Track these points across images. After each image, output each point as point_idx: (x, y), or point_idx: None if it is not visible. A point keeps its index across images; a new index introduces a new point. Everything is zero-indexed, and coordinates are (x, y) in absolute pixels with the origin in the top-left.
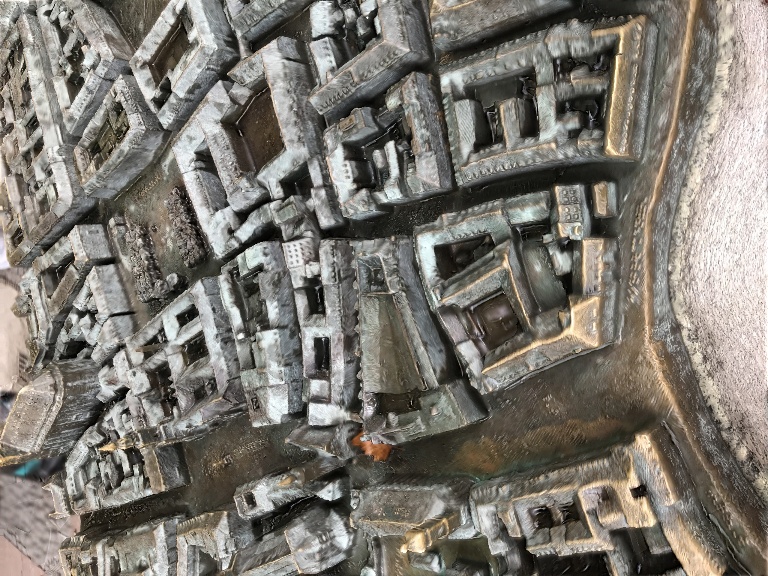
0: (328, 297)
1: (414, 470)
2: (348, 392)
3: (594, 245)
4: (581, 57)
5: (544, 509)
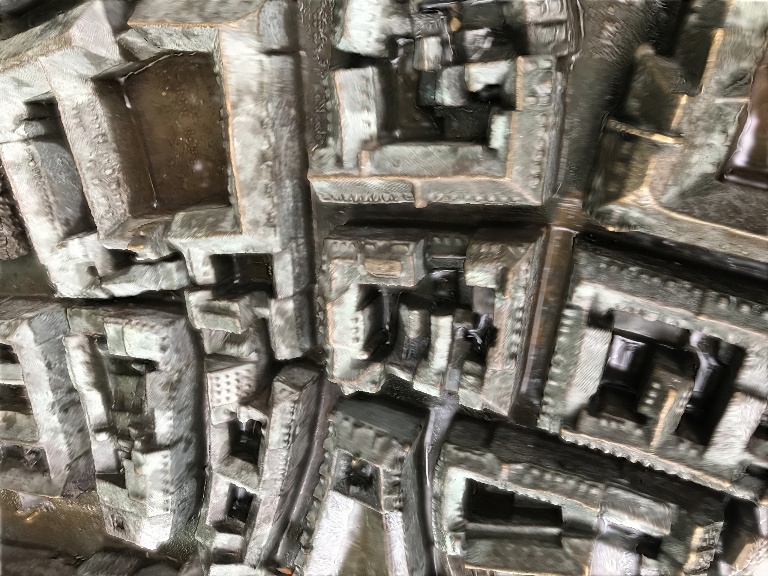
0: (270, 459)
1: None
2: (267, 546)
3: None
4: None
5: None
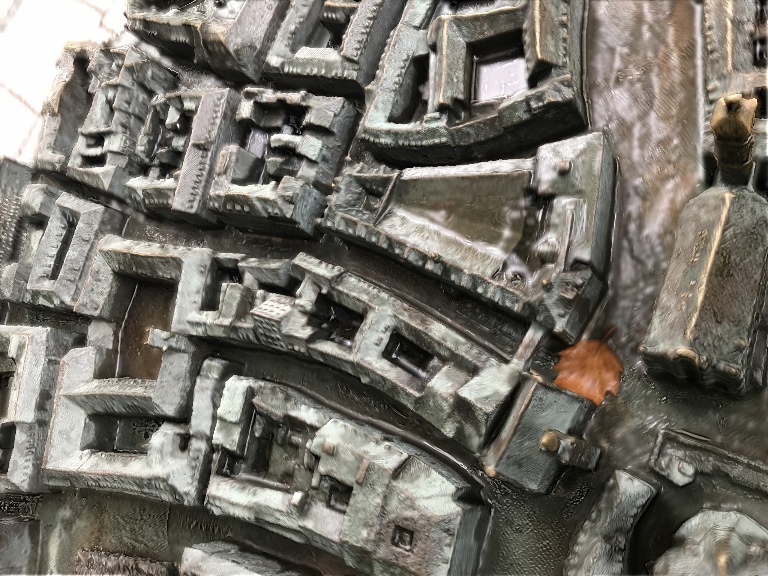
0: (348, 288)
1: None
2: None
3: None
4: None
5: (759, 44)
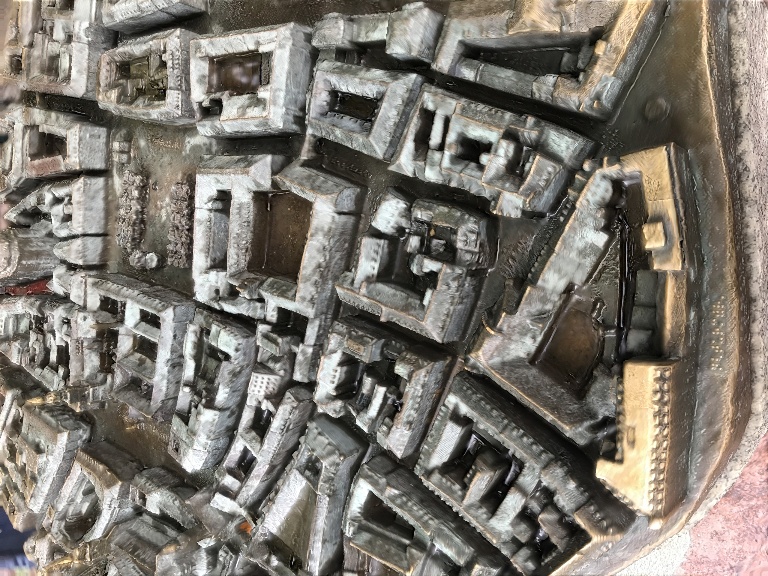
0: (270, 437)
1: None
2: (253, 496)
3: None
4: None
5: None
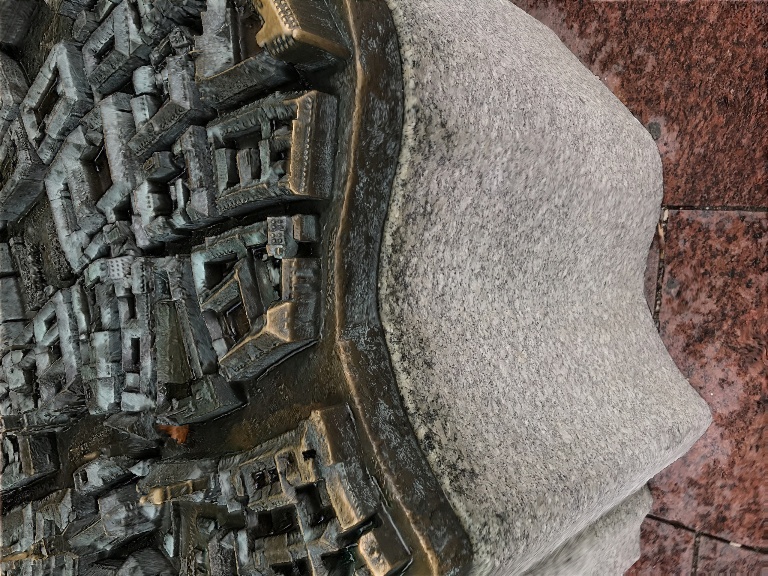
0: (138, 304)
1: (201, 449)
2: None
3: (289, 263)
4: (283, 120)
5: (261, 473)
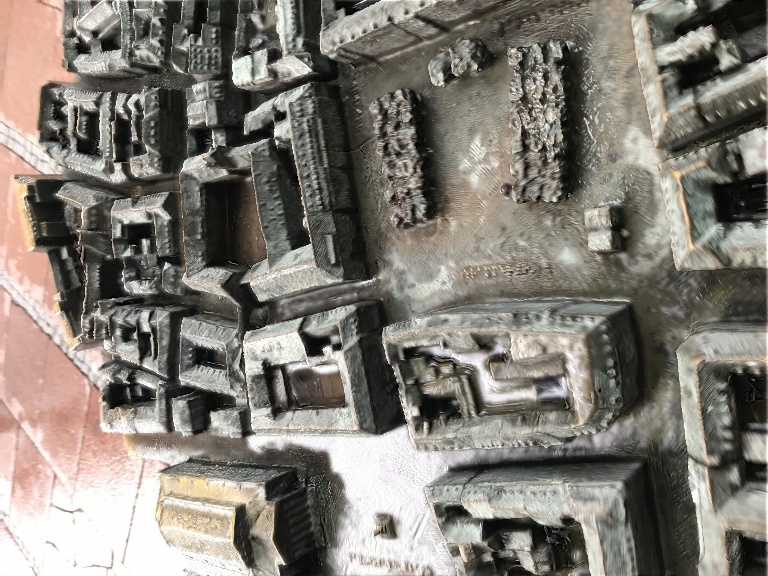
0: None
1: None
2: None
3: None
4: None
5: None
